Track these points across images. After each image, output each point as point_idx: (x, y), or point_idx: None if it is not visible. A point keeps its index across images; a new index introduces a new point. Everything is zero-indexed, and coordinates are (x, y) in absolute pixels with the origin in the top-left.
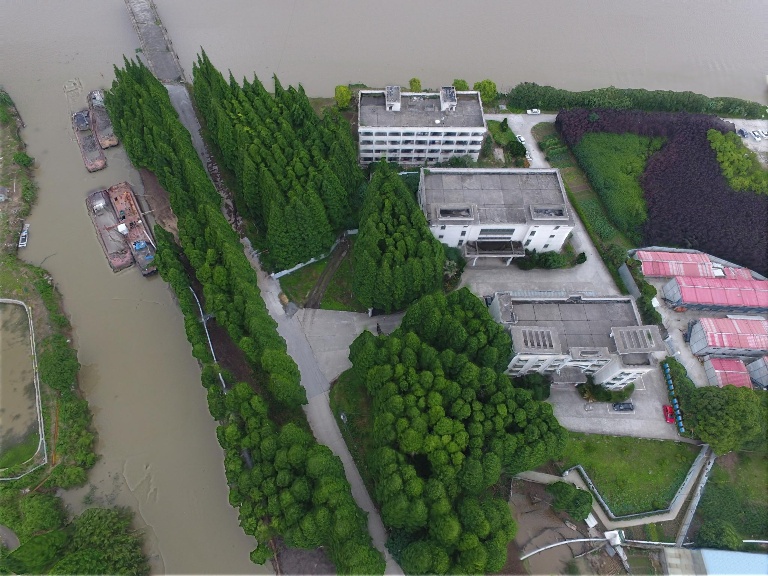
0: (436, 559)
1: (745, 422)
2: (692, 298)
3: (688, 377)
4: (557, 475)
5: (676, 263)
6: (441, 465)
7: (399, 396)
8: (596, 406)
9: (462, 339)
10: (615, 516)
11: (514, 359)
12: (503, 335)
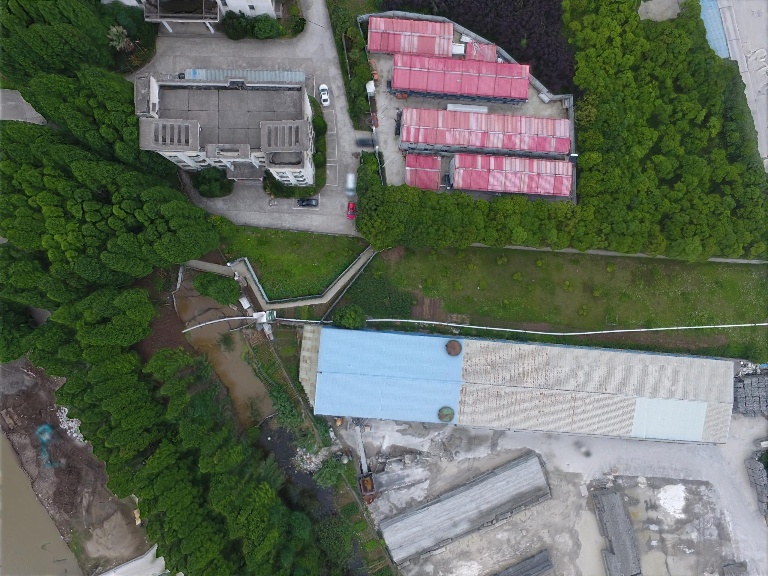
0: (38, 339)
1: (388, 223)
2: (404, 83)
3: (379, 174)
4: (225, 265)
5: (410, 35)
6: (53, 262)
7: (3, 196)
8: (281, 201)
9: (77, 133)
10: (272, 300)
11: (163, 154)
12: (125, 129)
